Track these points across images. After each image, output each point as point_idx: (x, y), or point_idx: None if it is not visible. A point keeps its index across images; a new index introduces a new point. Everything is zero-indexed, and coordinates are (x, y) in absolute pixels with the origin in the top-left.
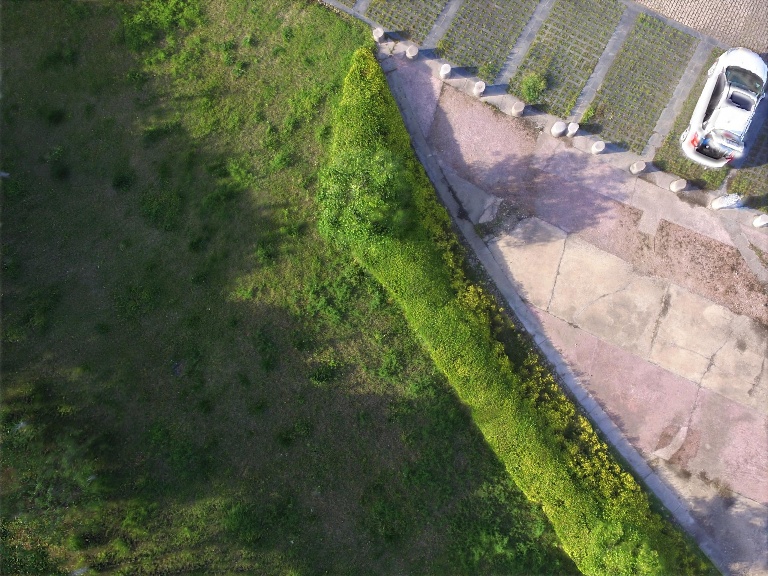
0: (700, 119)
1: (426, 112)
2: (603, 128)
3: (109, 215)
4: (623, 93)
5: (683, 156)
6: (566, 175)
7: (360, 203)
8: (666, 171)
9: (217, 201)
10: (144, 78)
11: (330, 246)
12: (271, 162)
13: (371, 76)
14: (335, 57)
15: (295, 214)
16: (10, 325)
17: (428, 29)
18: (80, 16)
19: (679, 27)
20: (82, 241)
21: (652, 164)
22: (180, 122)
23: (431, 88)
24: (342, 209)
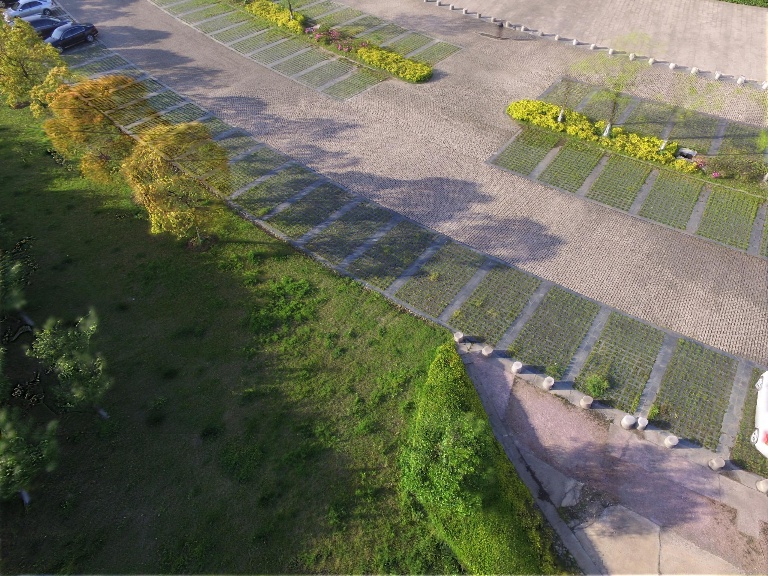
0: (766, 423)
1: (501, 398)
2: (671, 425)
3: (188, 463)
4: (682, 397)
5: (759, 457)
6: (645, 465)
7: (449, 469)
8: (747, 470)
9: (297, 459)
10: (256, 352)
11: (405, 516)
12: (355, 428)
13: (453, 365)
14: (421, 349)
15: (372, 479)
16: (37, 574)
17: (499, 336)
18: (219, 306)
19: (716, 351)
20: (152, 486)
21: (730, 462)
22: (278, 387)
23: (504, 379)
24: (429, 474)
